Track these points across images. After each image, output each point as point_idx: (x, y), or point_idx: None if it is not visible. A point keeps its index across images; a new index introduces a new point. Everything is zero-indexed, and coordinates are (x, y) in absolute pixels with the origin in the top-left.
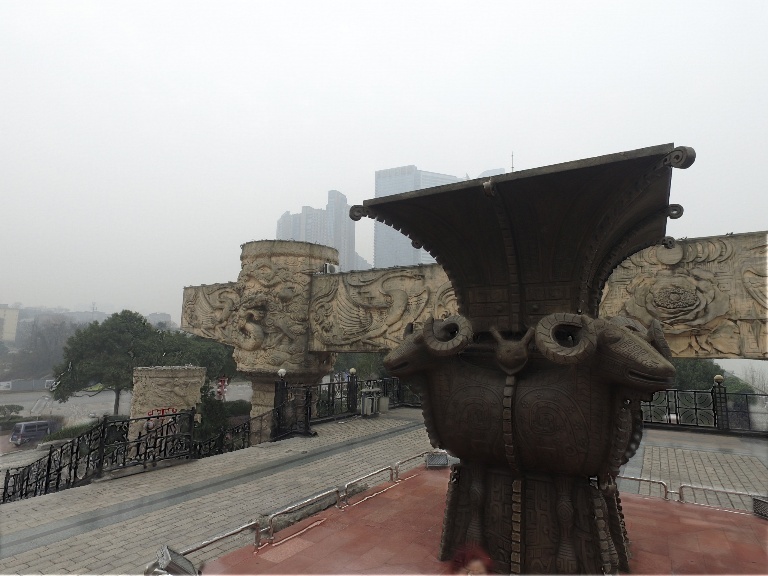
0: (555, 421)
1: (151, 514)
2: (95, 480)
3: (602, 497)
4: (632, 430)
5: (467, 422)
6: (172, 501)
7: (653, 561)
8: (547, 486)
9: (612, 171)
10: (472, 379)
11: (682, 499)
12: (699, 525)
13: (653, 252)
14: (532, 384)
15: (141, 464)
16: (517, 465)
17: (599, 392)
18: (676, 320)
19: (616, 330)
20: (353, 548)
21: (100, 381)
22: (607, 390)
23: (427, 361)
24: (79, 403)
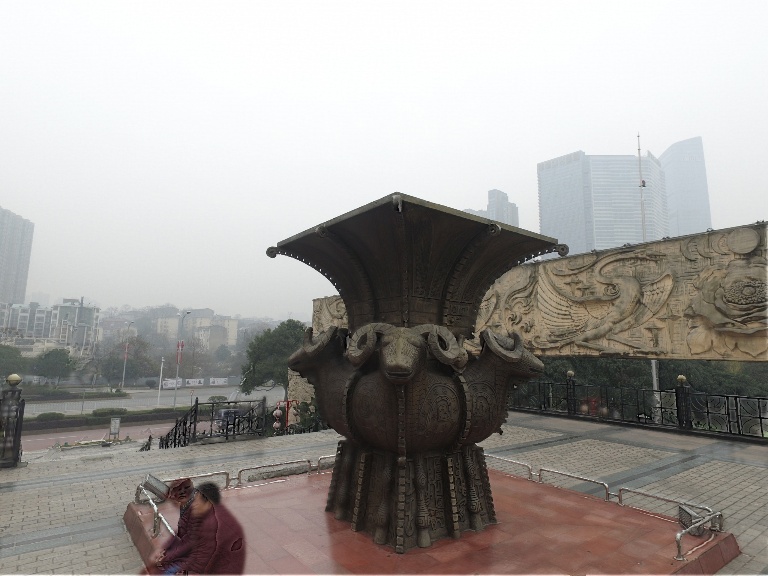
0: (369, 407)
1: (201, 467)
2: (190, 444)
3: (421, 471)
4: (460, 420)
5: (333, 407)
6: (222, 461)
7: (492, 536)
8: (383, 459)
9: (379, 214)
10: (341, 374)
11: (621, 502)
12: (596, 522)
13: (723, 241)
14: (367, 378)
15: (224, 436)
16: (357, 440)
17: (387, 384)
18: (749, 318)
19: (392, 336)
20: (281, 497)
21: (272, 378)
22: (392, 383)
23: (313, 360)
24: (259, 396)
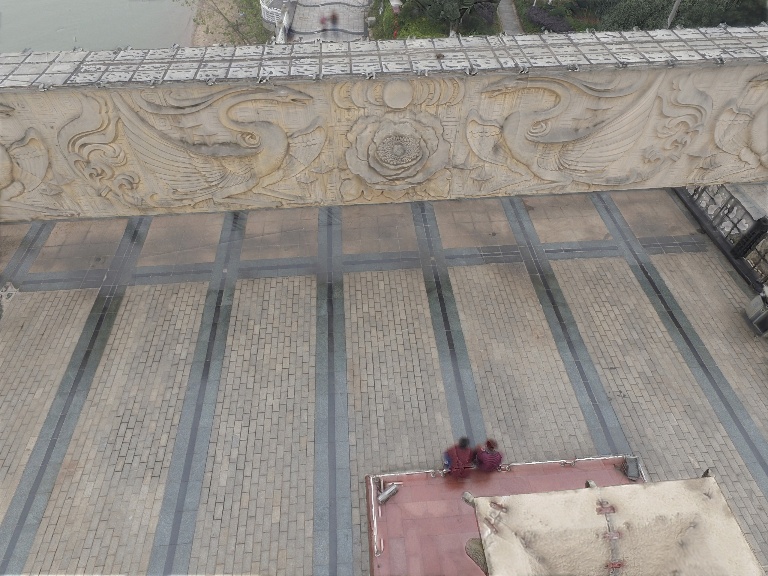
0: None
1: None
2: None
3: None
4: None
5: None
6: None
7: None
8: None
9: None
10: None
11: None
12: None
13: None
14: None
15: None
16: None
17: None
18: None
19: None
20: None
21: None
22: None
23: None
24: None
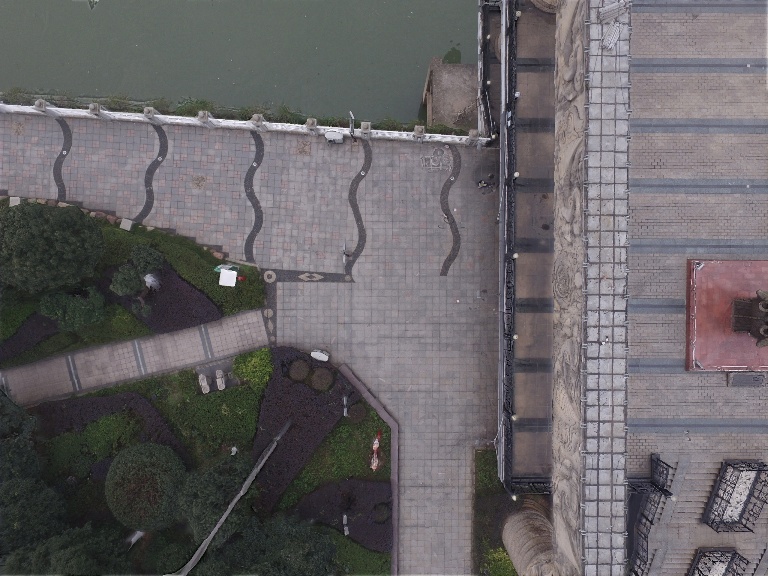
0: None
1: None
2: None
3: None
4: None
5: None
6: (760, 422)
7: (742, 294)
8: None
9: None
10: None
11: None
12: (712, 284)
13: None
14: None
15: None
16: None
17: None
18: None
19: None
20: None
21: None
22: None
23: None
24: None
